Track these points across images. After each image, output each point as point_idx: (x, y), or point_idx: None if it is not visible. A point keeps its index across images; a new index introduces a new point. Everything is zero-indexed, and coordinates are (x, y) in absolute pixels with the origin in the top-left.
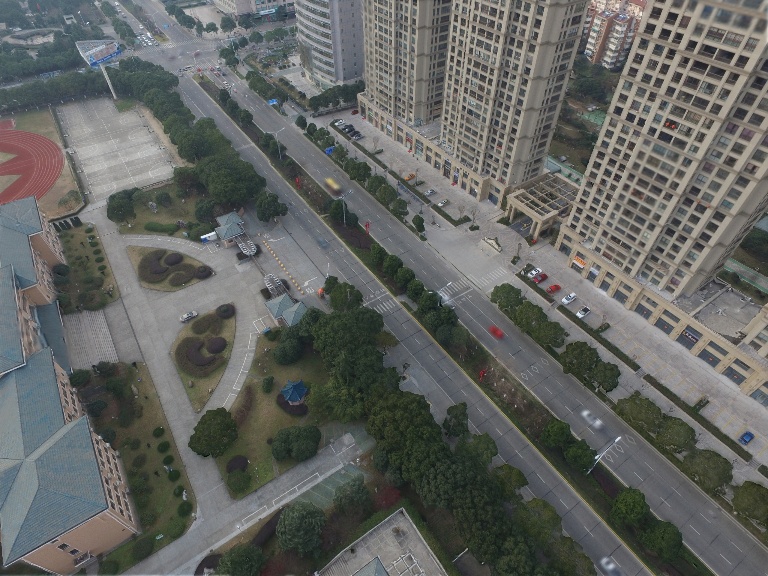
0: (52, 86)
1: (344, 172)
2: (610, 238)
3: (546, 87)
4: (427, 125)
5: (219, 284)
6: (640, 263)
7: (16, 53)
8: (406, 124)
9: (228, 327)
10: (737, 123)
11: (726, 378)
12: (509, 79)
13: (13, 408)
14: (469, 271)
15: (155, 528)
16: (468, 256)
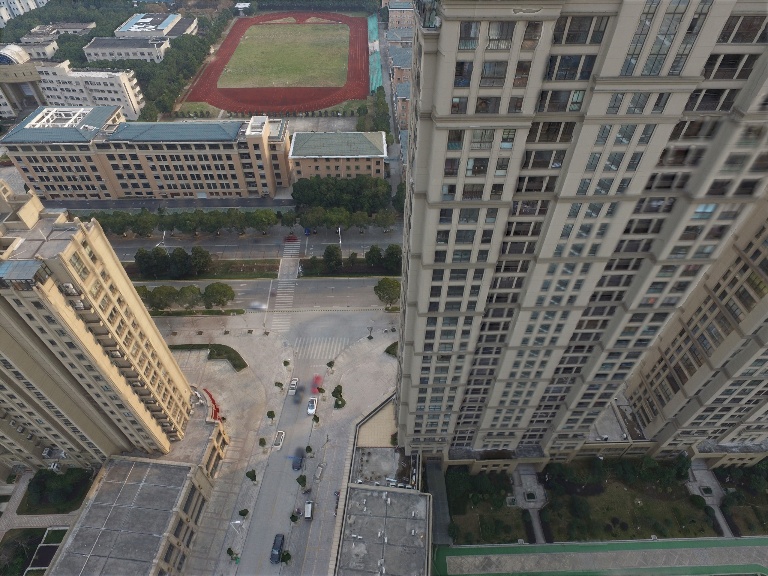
0: None
1: None
2: None
3: None
4: None
5: None
6: None
7: None
8: None
9: None
10: None
11: None
12: None
13: None
14: None
15: None
16: None
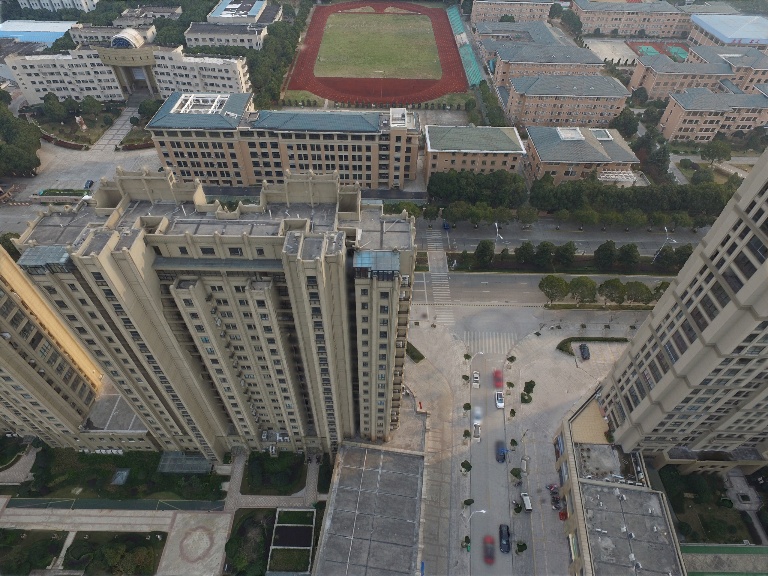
0: None
1: None
2: None
3: None
4: None
5: None
6: None
7: None
8: None
9: None
10: None
11: None
12: None
13: None
14: None
15: None
16: None
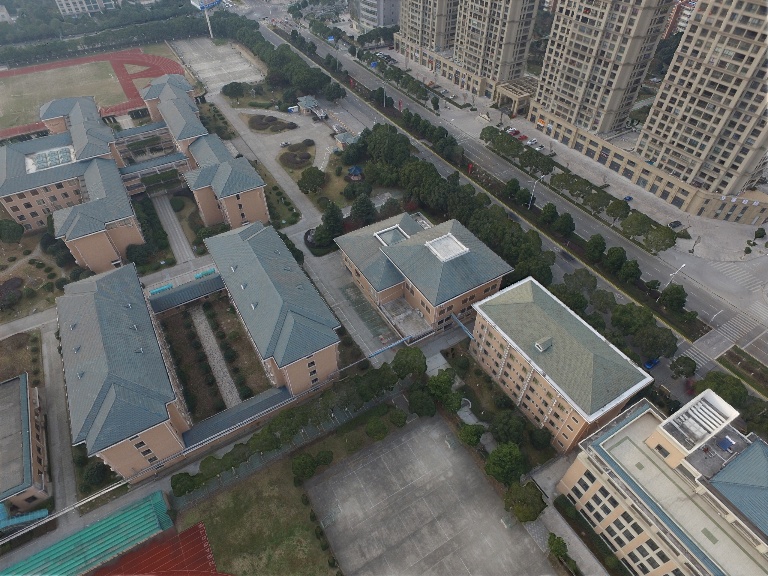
0: (169, 25)
1: (383, 81)
2: (559, 100)
3: (522, 5)
4: (444, 51)
5: (302, 131)
6: (576, 112)
7: (136, 6)
8: (429, 50)
9: (311, 150)
10: (619, 3)
11: (624, 177)
12: (498, 1)
13: (207, 149)
14: (468, 130)
15: (280, 221)
16: (468, 123)
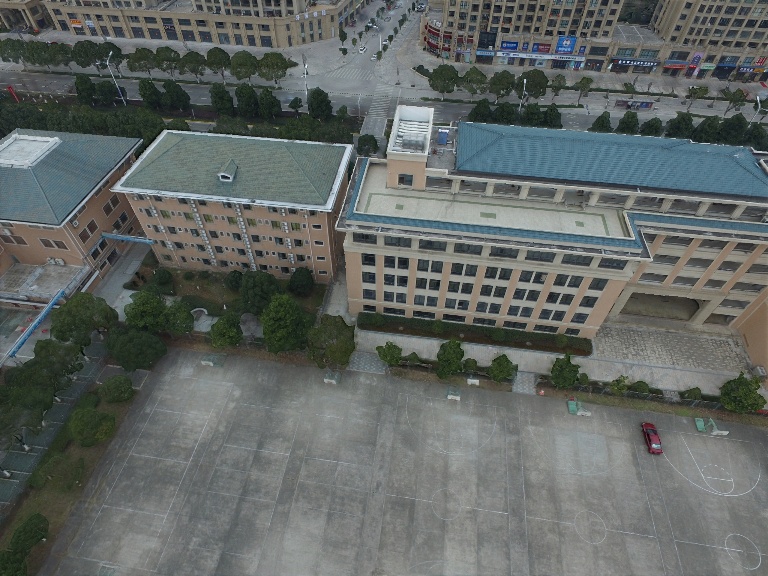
0: None
1: None
2: None
3: None
4: None
5: None
6: None
7: None
8: None
9: None
10: None
11: (205, 43)
12: None
13: None
14: None
15: None
16: None
